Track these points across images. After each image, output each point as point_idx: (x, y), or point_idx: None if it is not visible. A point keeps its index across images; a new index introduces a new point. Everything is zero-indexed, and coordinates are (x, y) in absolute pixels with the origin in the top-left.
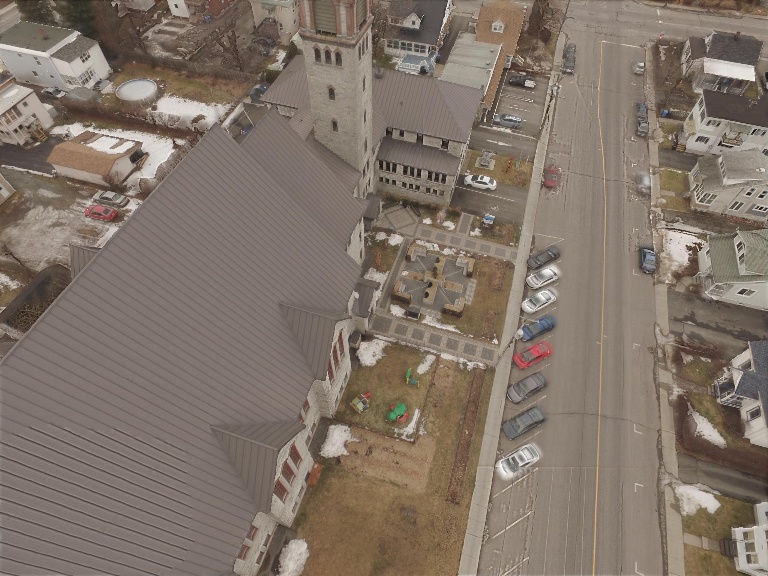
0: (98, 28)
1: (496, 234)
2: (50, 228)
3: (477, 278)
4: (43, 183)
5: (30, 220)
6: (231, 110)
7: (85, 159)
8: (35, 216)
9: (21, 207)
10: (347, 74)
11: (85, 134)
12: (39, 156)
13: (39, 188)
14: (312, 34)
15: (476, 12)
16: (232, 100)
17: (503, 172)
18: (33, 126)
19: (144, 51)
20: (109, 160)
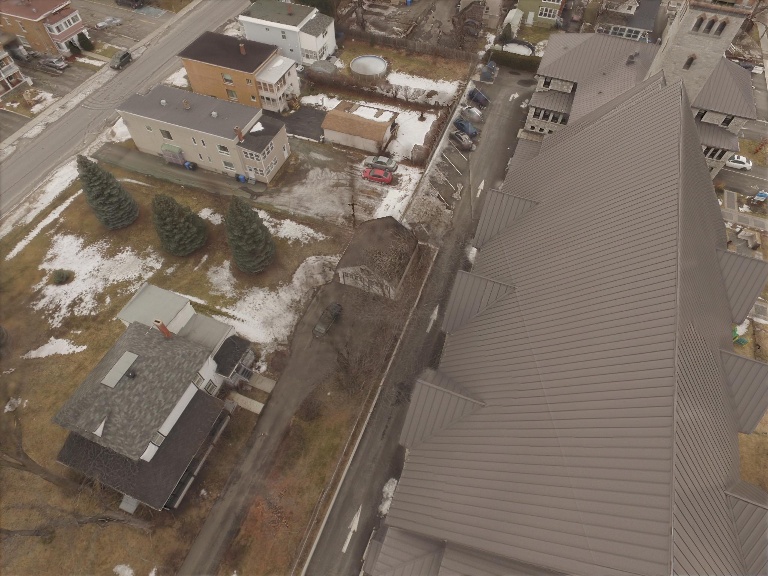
0: (330, 6)
1: (766, 211)
2: (334, 188)
3: (762, 251)
4: (312, 147)
5: (313, 180)
6: (461, 87)
7: (358, 125)
8: (316, 176)
9: (300, 168)
10: (721, 43)
11: (344, 103)
12: (298, 123)
13: (310, 151)
14: (707, 3)
15: (671, 1)
16: (457, 78)
17: (750, 153)
18: (289, 95)
19: (363, 30)
20: (382, 127)
